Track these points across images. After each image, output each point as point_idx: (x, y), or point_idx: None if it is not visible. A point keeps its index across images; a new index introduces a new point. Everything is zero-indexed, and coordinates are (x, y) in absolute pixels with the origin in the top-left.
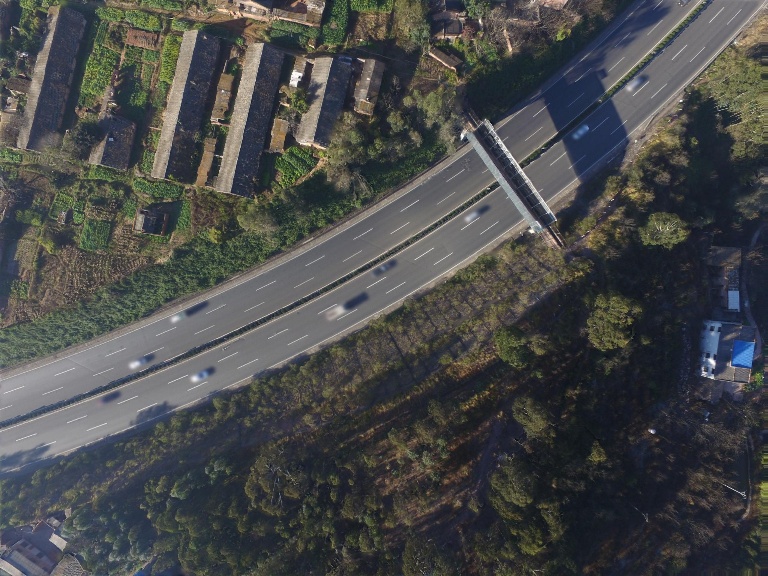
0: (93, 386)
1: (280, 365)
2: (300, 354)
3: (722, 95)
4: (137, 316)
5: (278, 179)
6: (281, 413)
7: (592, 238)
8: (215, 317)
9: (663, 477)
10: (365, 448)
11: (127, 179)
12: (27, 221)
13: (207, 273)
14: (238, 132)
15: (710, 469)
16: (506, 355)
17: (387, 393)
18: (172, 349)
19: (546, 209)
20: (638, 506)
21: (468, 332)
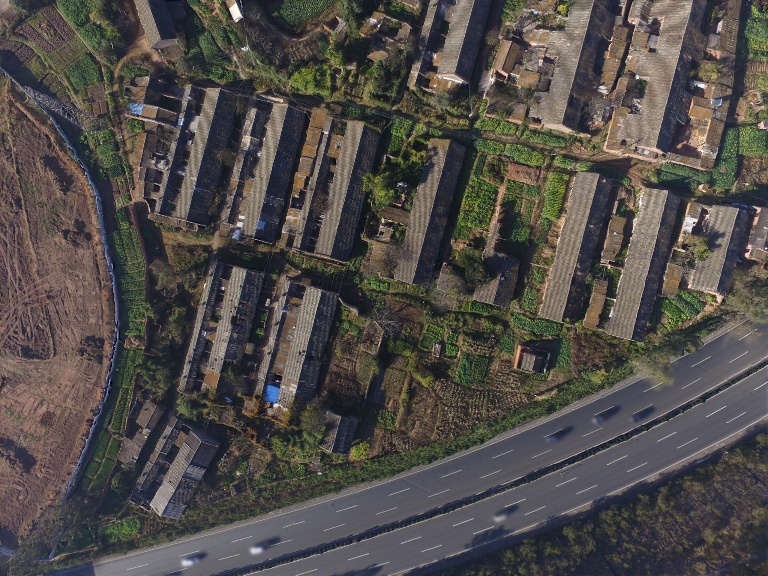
0: (428, 507)
1: (620, 492)
2: (640, 482)
3: None
4: (483, 441)
5: (664, 321)
6: (657, 554)
7: None
8: (553, 441)
9: None
10: None
11: (503, 313)
12: (398, 352)
13: None
14: (637, 278)
15: None
16: None
17: None
18: (509, 472)
19: None
20: None
21: None
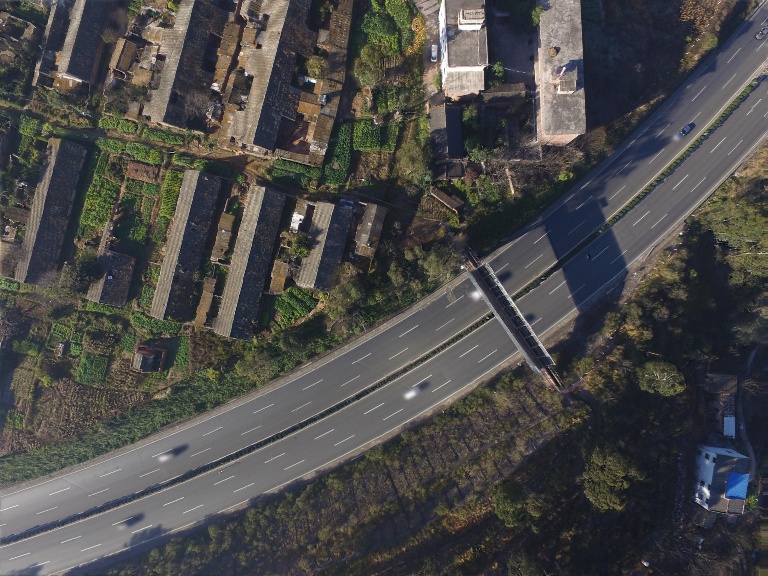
0: (88, 506)
1: (276, 490)
2: (296, 479)
3: (722, 233)
4: (133, 440)
5: (277, 319)
6: (276, 552)
7: (590, 380)
8: (212, 439)
9: None
10: None
11: (125, 312)
12: (24, 352)
13: (204, 399)
14: (238, 275)
15: None
16: (502, 515)
17: (383, 540)
18: (168, 471)
19: (545, 352)
20: None
21: (465, 477)
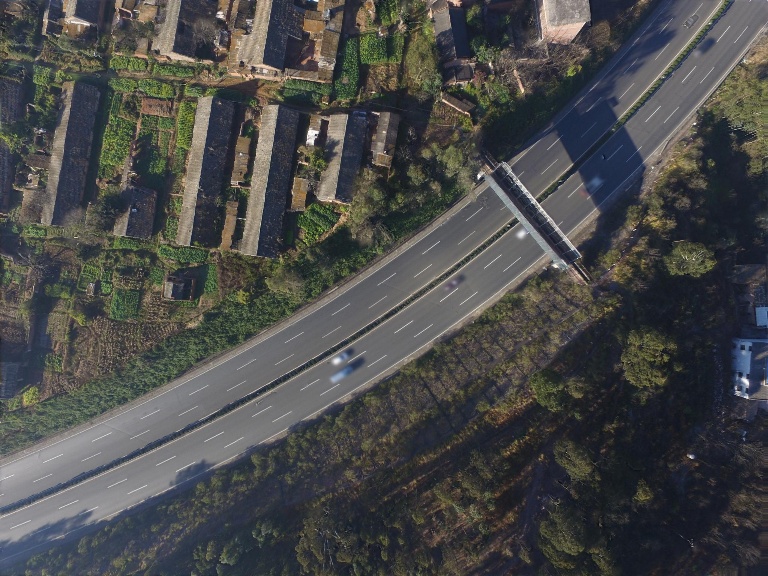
0: (131, 449)
1: (314, 416)
2: (333, 404)
3: (736, 116)
4: (170, 378)
5: (301, 237)
6: (321, 468)
7: (618, 271)
8: (246, 372)
9: (705, 502)
10: (409, 501)
11: (152, 246)
12: (56, 295)
13: (236, 331)
14: (259, 194)
15: (751, 489)
16: (544, 401)
17: (426, 443)
18: (206, 407)
19: (570, 246)
20: (683, 533)
21: (502, 375)
